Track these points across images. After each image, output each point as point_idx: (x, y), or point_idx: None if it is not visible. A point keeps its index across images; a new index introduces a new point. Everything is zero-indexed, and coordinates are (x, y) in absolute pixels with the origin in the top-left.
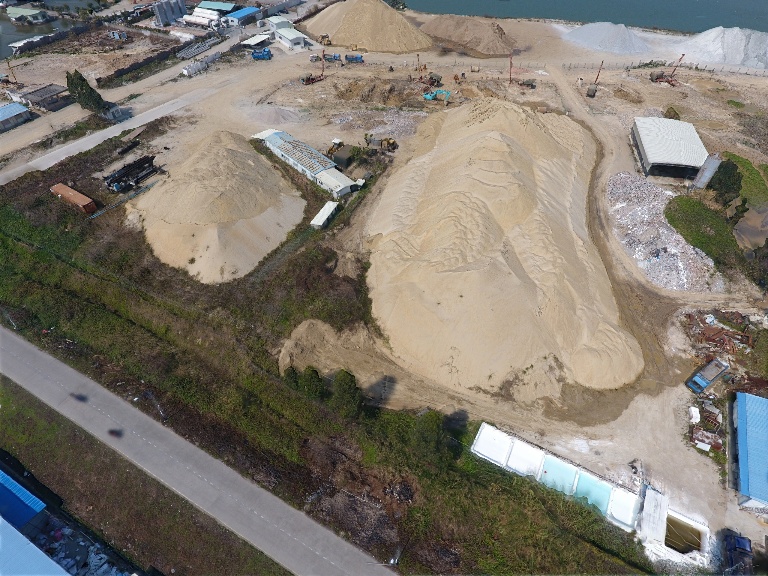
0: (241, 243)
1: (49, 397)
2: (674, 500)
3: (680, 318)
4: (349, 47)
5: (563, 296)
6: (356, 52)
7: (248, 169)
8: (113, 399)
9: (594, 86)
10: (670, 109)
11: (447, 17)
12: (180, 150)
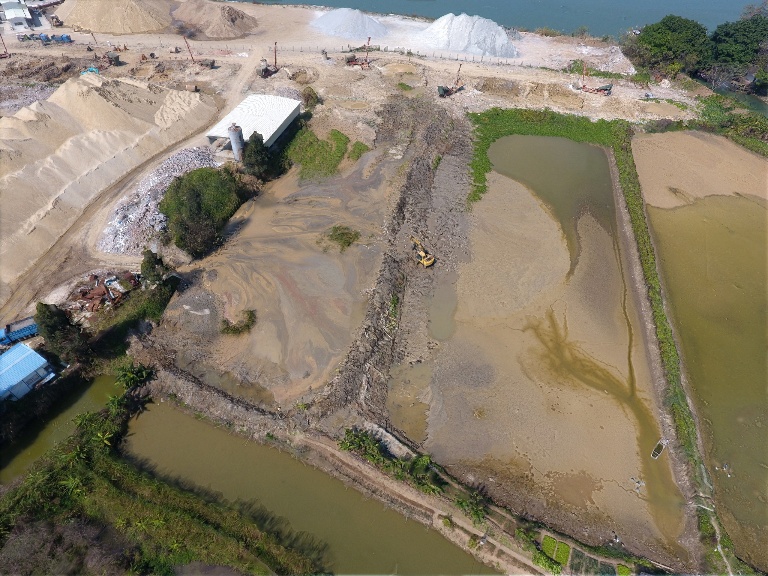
0: None
1: None
2: None
3: (83, 278)
4: (71, 28)
5: None
6: (77, 33)
7: None
8: None
9: (263, 67)
10: (307, 88)
11: (192, 1)
12: None
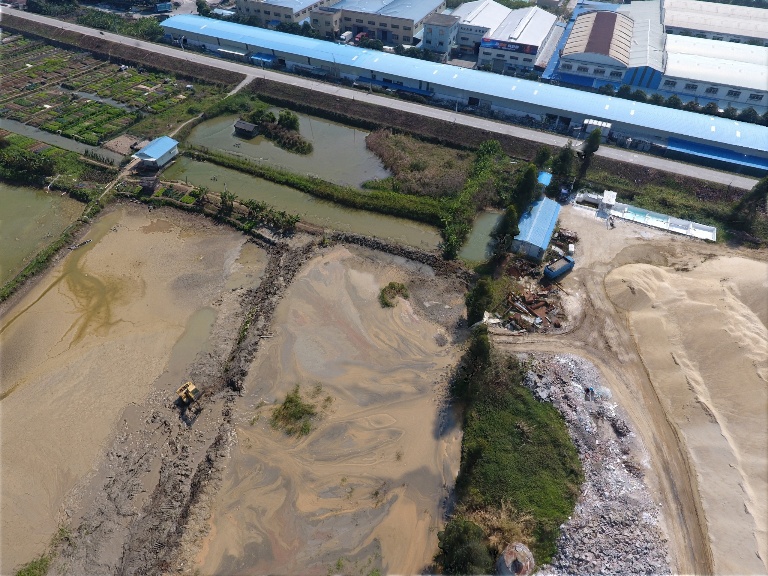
0: None
1: None
2: (590, 214)
3: (567, 324)
4: None
5: (709, 294)
6: None
7: None
8: None
9: None
10: None
11: None
12: None
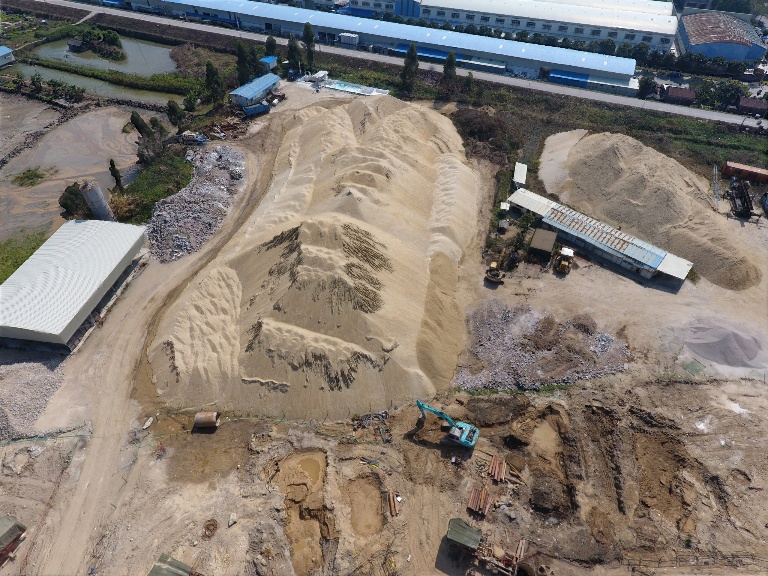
0: (565, 139)
1: (589, 92)
2: None
3: None
4: None
5: None
6: None
7: (623, 184)
8: None
9: None
10: None
11: None
12: (760, 249)
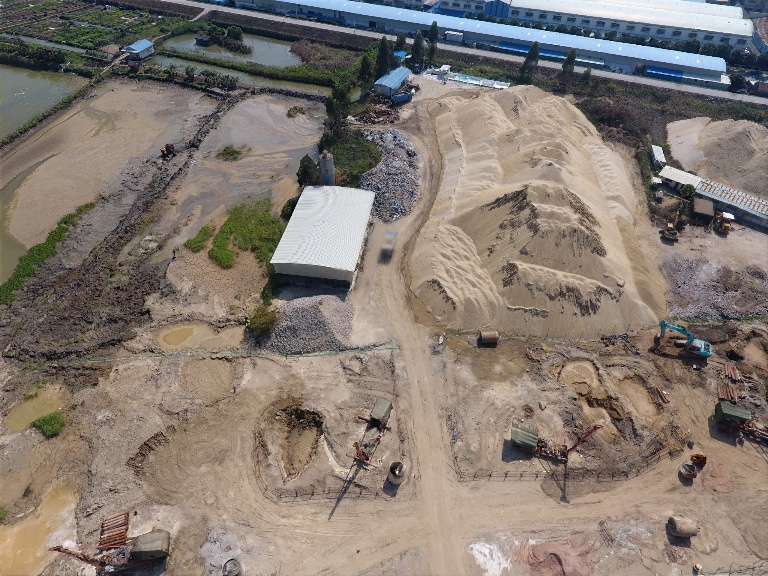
0: None
1: None
2: (432, 78)
3: (398, 121)
4: None
5: None
6: None
7: (758, 162)
8: (663, 86)
9: (379, 410)
10: (267, 318)
11: None
12: None
